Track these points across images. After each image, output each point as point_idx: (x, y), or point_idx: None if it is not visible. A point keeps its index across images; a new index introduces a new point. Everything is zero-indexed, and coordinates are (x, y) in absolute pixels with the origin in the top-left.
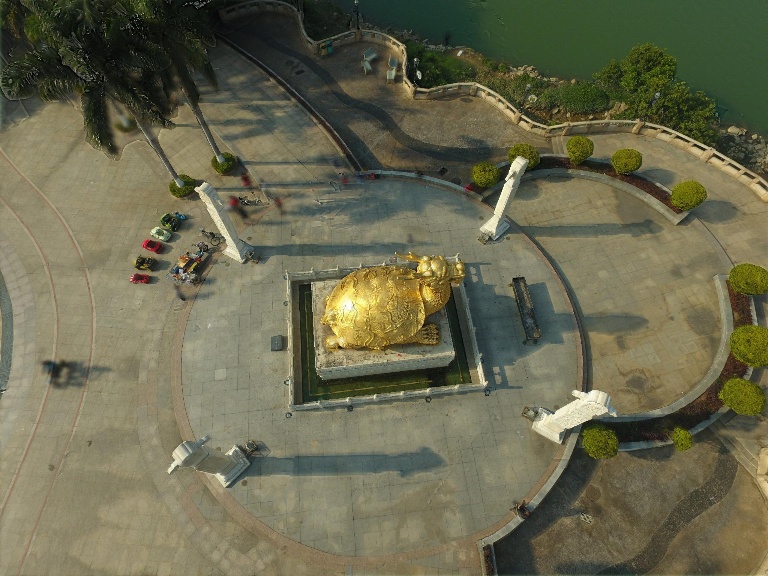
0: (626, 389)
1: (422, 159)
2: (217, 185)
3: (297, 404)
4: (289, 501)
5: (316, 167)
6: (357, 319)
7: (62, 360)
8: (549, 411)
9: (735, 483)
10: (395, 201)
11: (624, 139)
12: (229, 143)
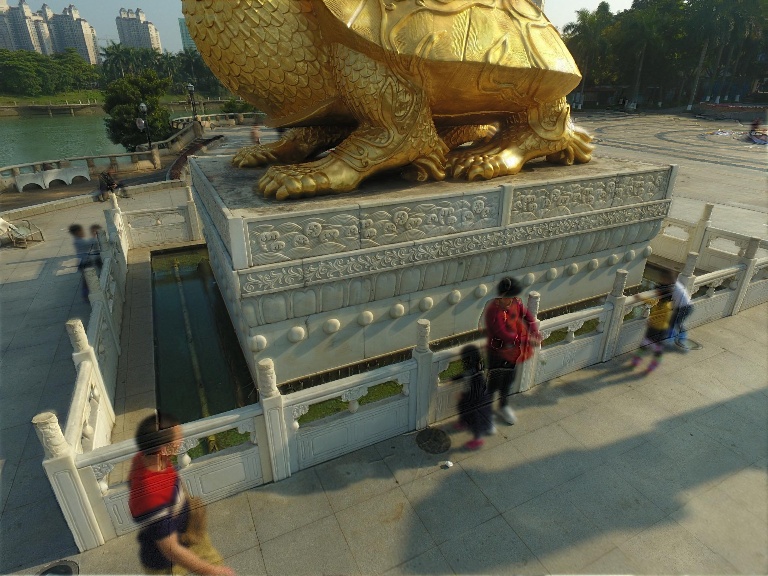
0: None
1: None
2: None
3: None
4: None
5: None
6: None
7: None
8: None
9: None
10: None
11: None
12: None
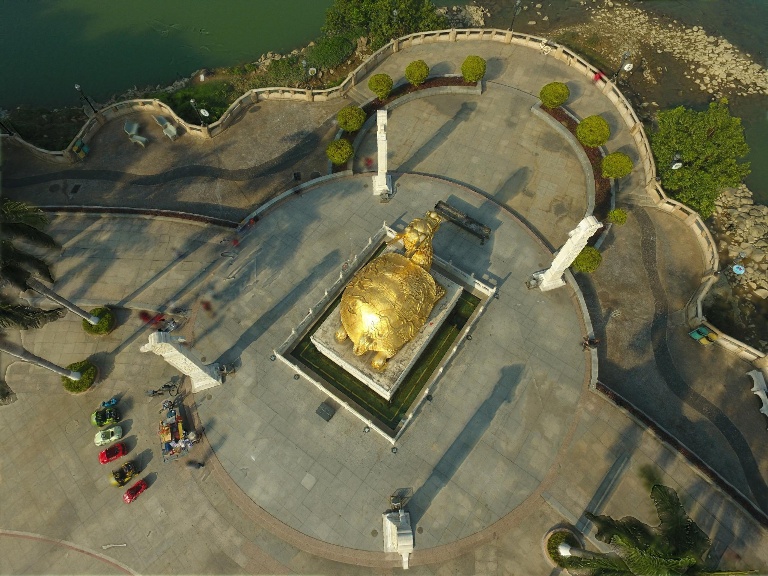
0: (559, 218)
1: (271, 179)
2: (113, 346)
3: (391, 436)
4: (463, 503)
5: (194, 253)
6: (391, 322)
7: None
8: (539, 271)
9: (652, 219)
10: (291, 226)
11: (394, 60)
12: (82, 301)
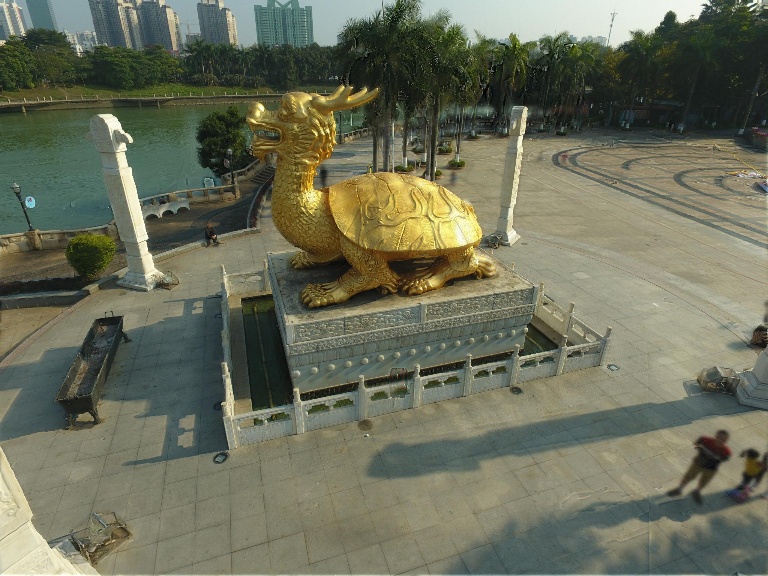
0: None
1: None
2: None
3: None
4: None
5: None
6: None
7: None
8: (137, 290)
9: None
10: None
11: None
12: None
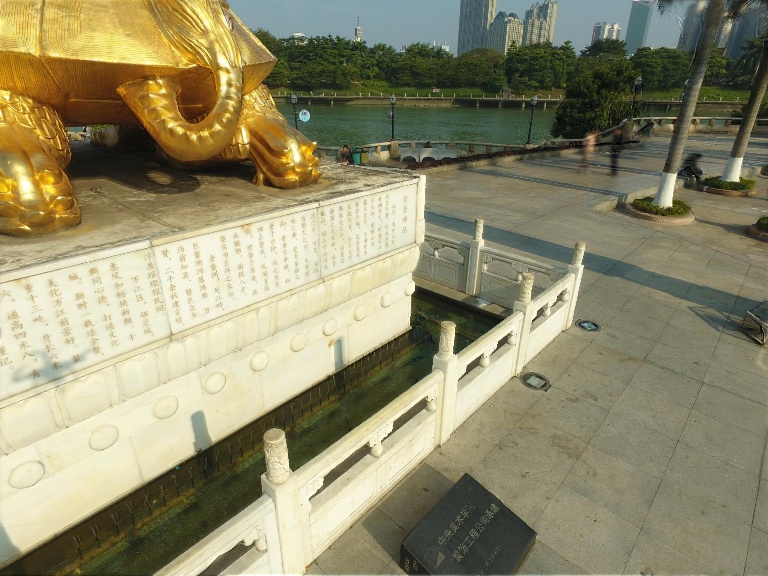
0: None
1: None
2: None
3: None
4: (663, 255)
5: None
6: None
7: None
8: None
9: None
10: None
11: None
12: None
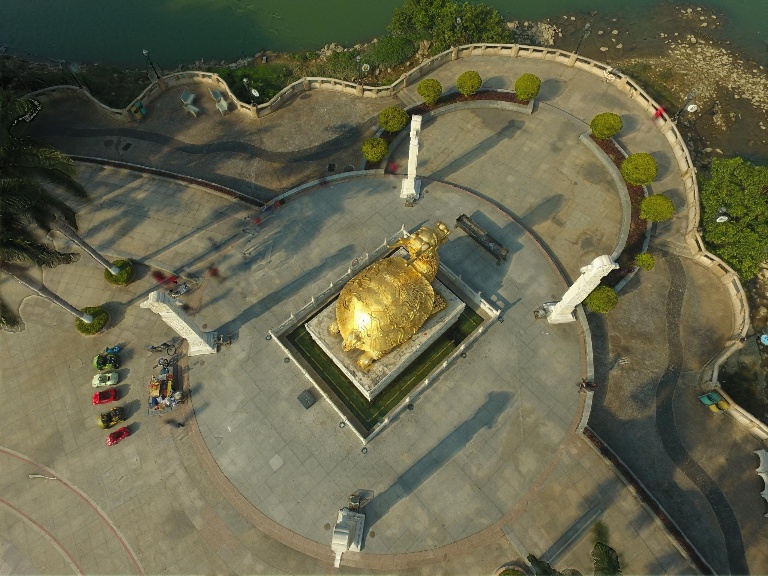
0: (584, 252)
1: (306, 166)
2: (128, 298)
3: (365, 436)
4: (420, 518)
5: (218, 225)
6: (382, 325)
7: (94, 573)
8: (551, 303)
9: (686, 270)
10: (314, 214)
11: (450, 68)
12: (109, 251)
